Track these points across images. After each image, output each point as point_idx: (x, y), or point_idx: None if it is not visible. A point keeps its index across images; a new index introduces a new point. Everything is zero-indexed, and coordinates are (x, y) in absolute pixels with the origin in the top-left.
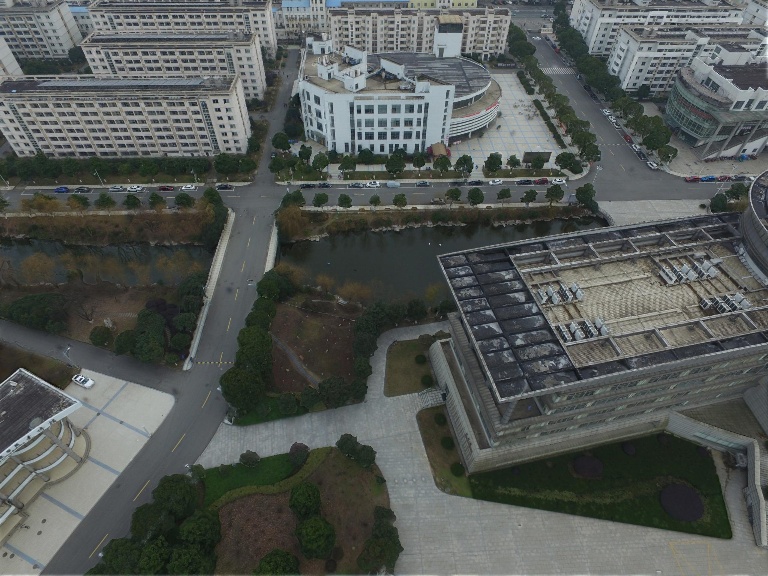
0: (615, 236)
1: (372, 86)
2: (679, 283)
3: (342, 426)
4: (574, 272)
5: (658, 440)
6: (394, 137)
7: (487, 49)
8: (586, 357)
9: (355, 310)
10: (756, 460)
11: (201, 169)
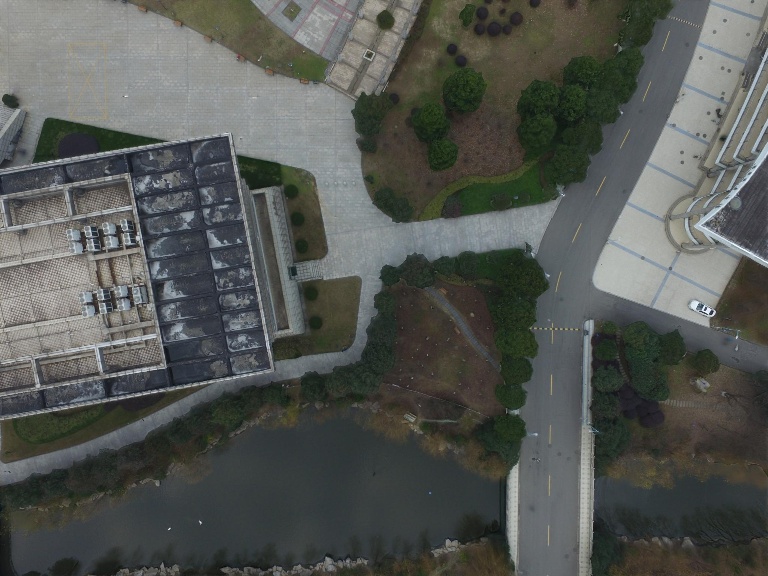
0: None
1: None
2: None
3: (408, 244)
4: None
5: None
6: None
7: None
8: (112, 204)
9: (393, 404)
10: None
11: None
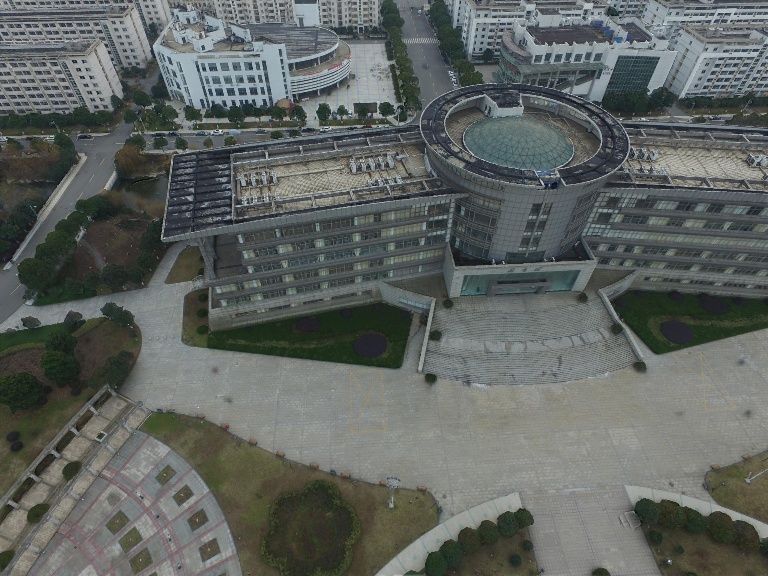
0: (327, 141)
1: (220, 48)
2: (362, 172)
3: (121, 304)
4: (285, 167)
5: (373, 307)
6: (242, 93)
7: (362, 22)
8: None
9: None
10: (430, 312)
11: (62, 121)
